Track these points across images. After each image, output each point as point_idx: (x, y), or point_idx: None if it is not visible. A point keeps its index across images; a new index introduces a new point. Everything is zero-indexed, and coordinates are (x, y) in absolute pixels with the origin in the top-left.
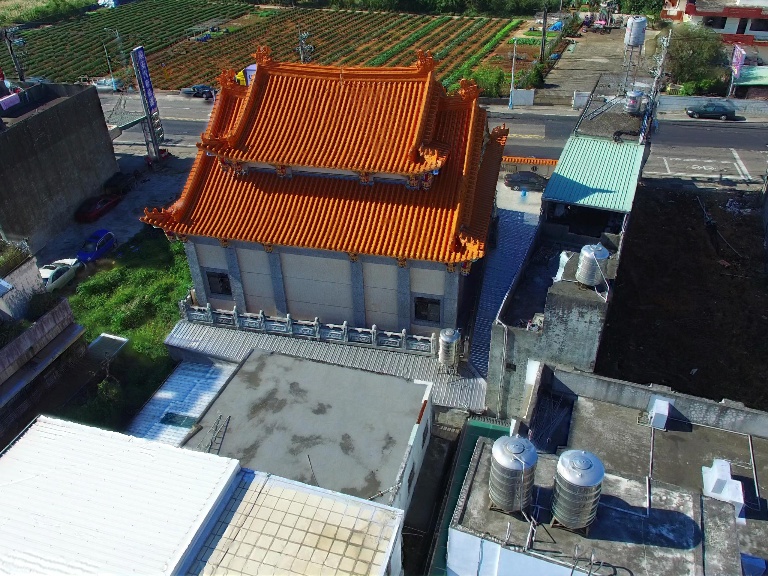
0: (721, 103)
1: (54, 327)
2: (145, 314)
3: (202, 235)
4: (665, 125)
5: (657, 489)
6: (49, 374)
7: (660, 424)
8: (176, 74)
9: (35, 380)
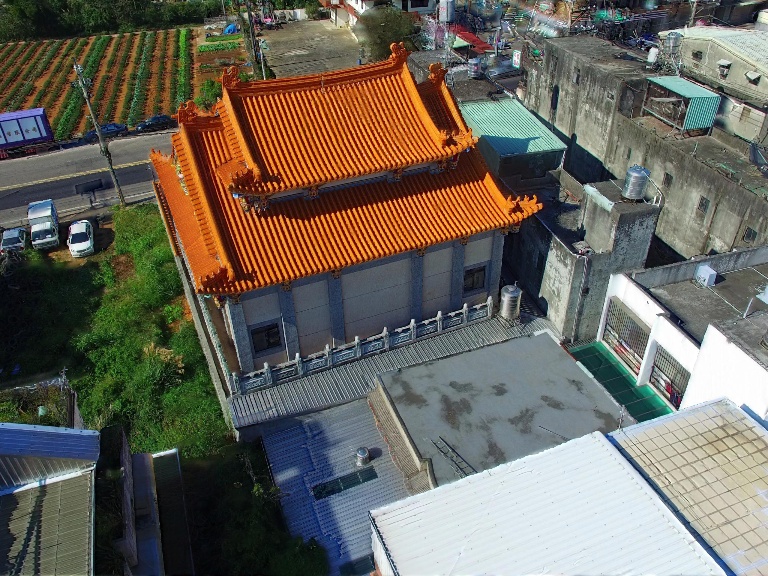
0: None
1: (128, 467)
2: None
3: (273, 284)
4: None
5: None
6: None
7: (711, 282)
8: None
9: None
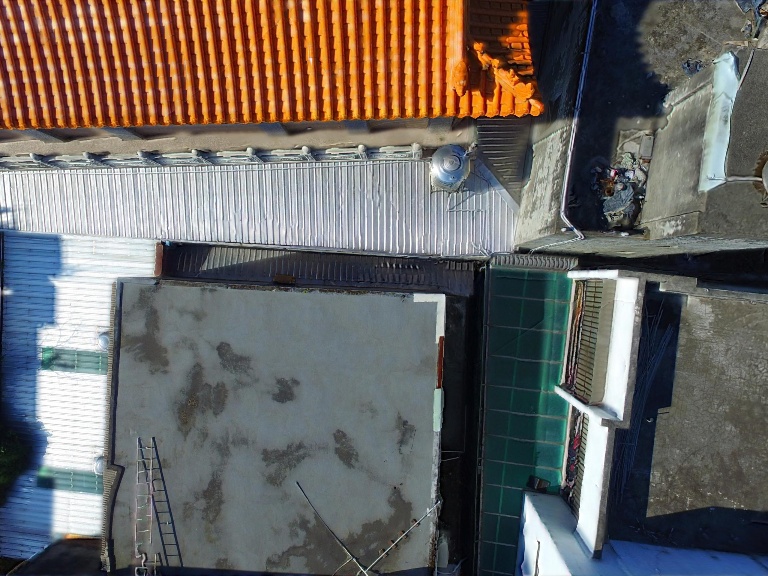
0: None
1: None
2: None
3: None
4: None
5: None
6: None
7: None
8: None
9: None
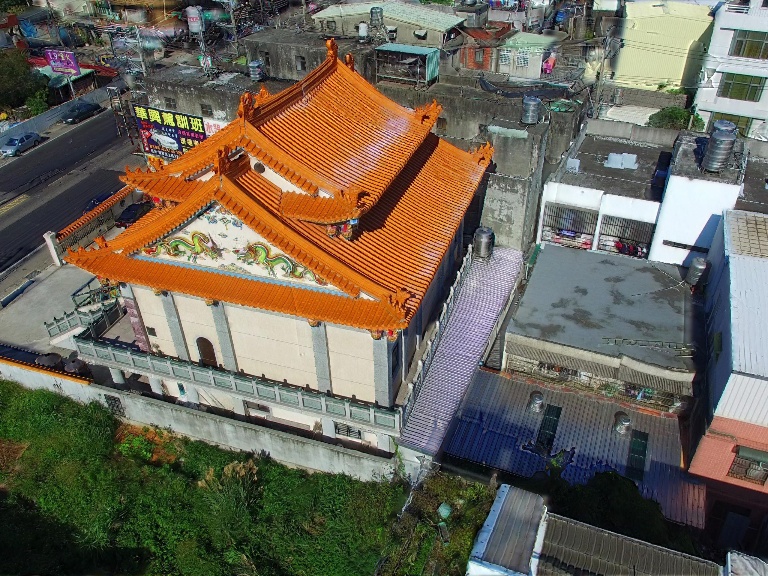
0: None
1: None
2: None
3: None
4: (77, 136)
5: (684, 141)
6: None
7: None
8: None
9: None
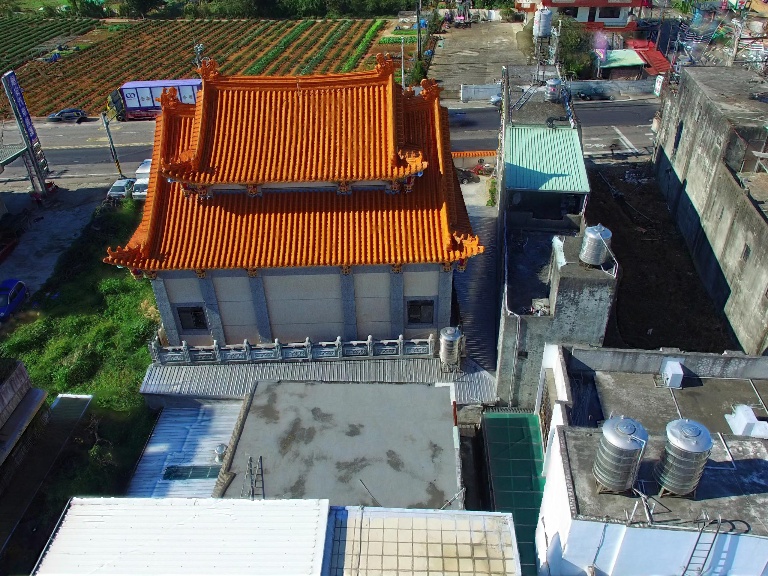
0: (608, 85)
1: (13, 397)
2: (91, 365)
3: (178, 269)
4: None
5: (731, 442)
6: (17, 451)
7: (676, 383)
8: (33, 99)
9: (4, 461)
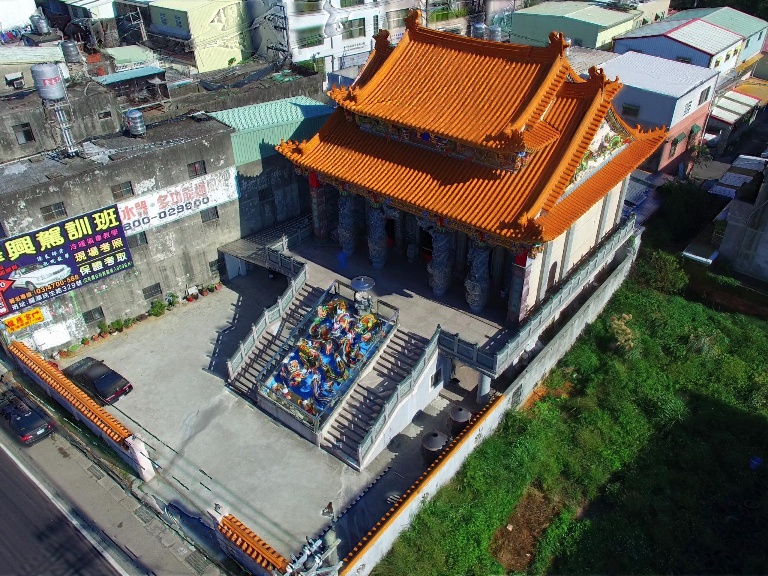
0: None
1: None
2: None
3: None
4: None
5: None
6: None
7: None
8: None
9: None
